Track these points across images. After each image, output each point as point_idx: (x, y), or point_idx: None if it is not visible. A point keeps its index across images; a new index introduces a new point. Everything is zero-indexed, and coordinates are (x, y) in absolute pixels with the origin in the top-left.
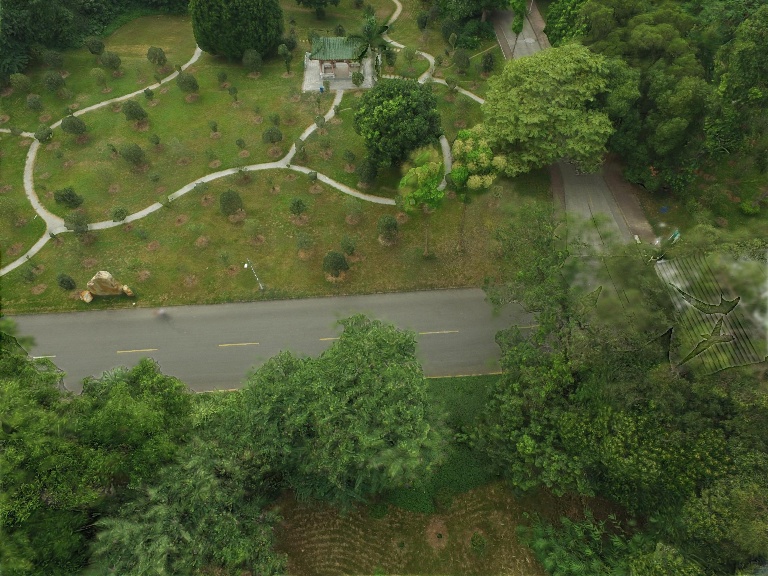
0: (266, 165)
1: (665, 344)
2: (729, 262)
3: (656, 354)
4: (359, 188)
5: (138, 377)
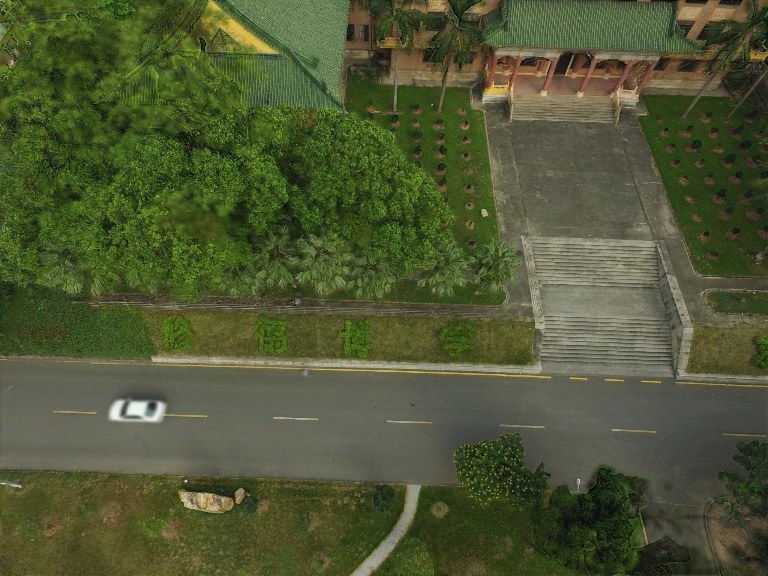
0: None
1: None
2: None
3: None
4: None
5: None
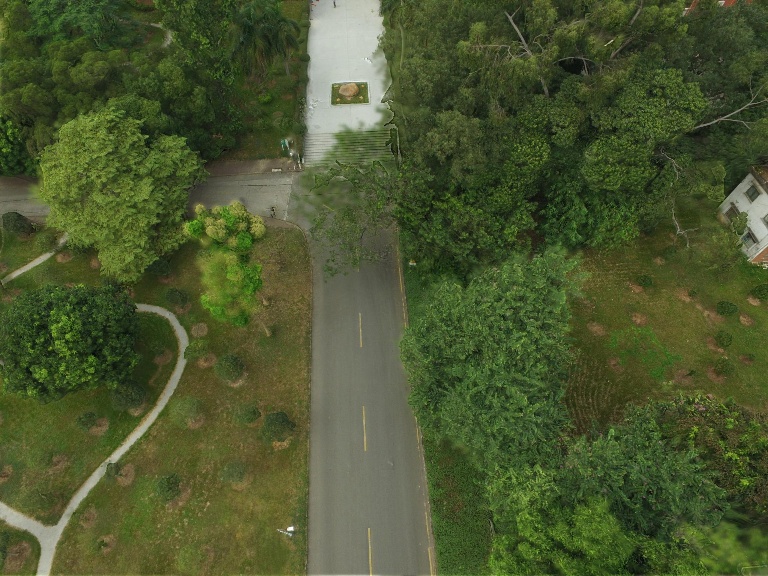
0: (42, 570)
1: (468, 118)
2: (314, 122)
3: (473, 125)
4: (142, 413)
5: (525, 575)
